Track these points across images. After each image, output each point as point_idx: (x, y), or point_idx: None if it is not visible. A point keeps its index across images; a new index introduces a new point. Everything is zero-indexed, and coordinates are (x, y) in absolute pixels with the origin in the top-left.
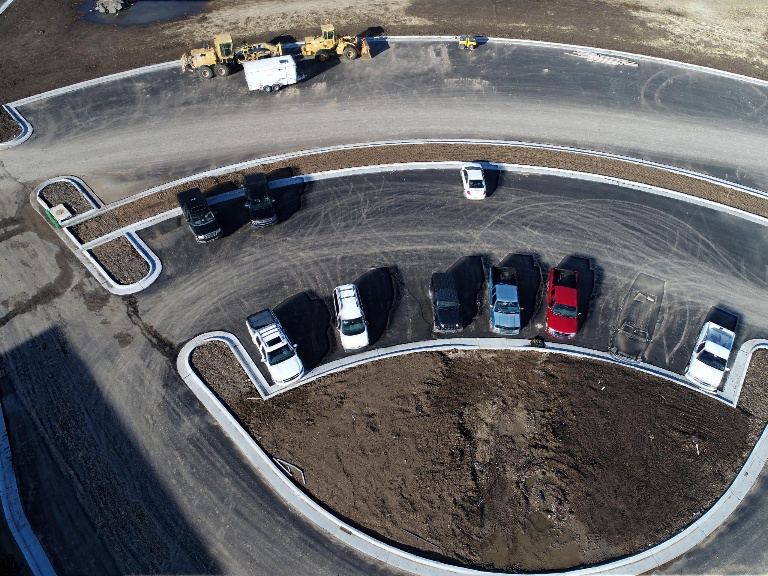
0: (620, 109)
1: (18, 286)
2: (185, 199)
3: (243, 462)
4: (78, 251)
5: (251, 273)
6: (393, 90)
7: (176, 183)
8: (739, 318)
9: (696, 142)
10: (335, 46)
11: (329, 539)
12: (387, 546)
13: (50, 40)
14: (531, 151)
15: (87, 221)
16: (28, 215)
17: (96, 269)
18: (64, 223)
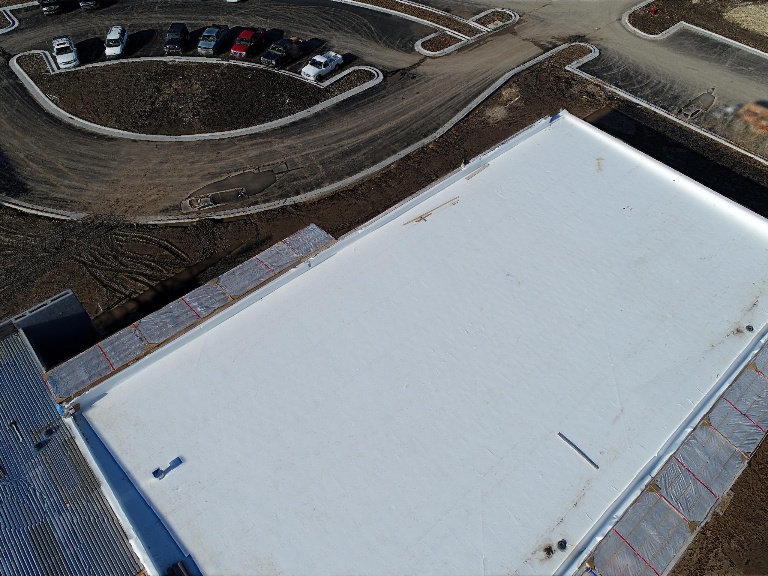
0: None
1: None
2: None
3: (29, 95)
4: None
5: (71, 29)
6: None
7: None
8: (360, 58)
9: None
10: None
11: (61, 120)
12: (89, 123)
13: None
14: None
15: None
16: None
17: None
18: None
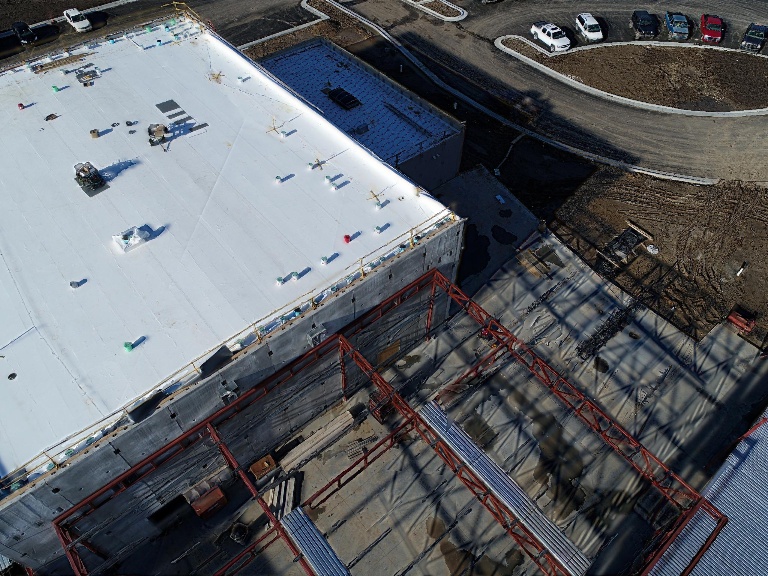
0: None
1: (390, 16)
2: None
3: (547, 75)
4: (415, 5)
5: (521, 16)
6: None
7: None
8: None
9: None
10: None
11: (602, 98)
12: (632, 100)
13: None
14: None
15: None
16: None
17: (430, 12)
18: None
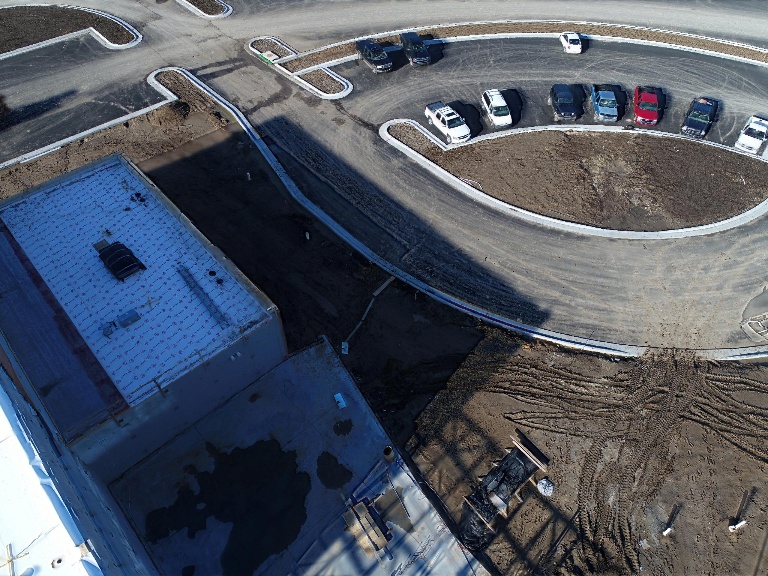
0: (679, 5)
1: (256, 93)
2: (363, 45)
3: (438, 179)
4: (290, 77)
5: (418, 90)
6: None
7: (348, 41)
8: None
9: (740, 26)
10: None
11: (503, 213)
12: (542, 216)
13: None
14: (612, 28)
15: (290, 61)
16: (247, 57)
17: (307, 86)
18: (275, 62)
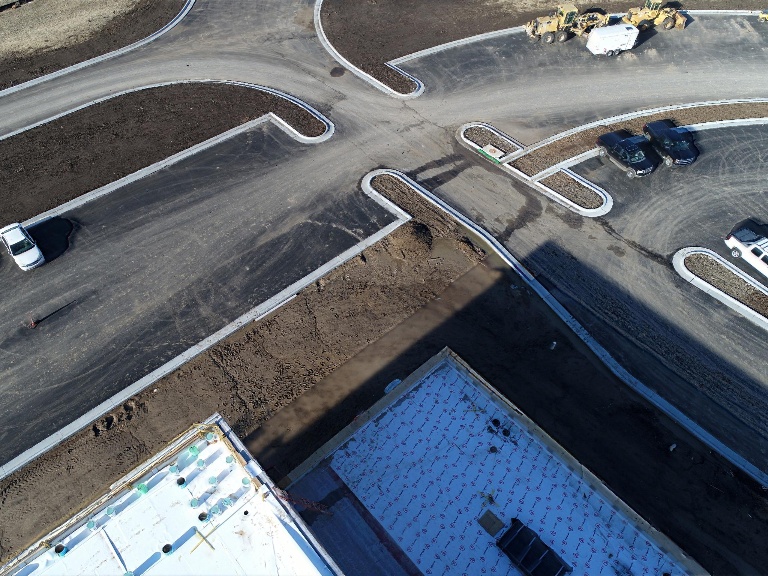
0: None
1: (499, 208)
2: (610, 141)
3: None
4: (529, 182)
5: (692, 203)
6: (720, 56)
7: (577, 130)
8: None
9: None
10: (655, 17)
11: None
12: None
13: (387, 9)
14: None
15: (519, 159)
16: (465, 153)
17: (555, 196)
18: (502, 160)
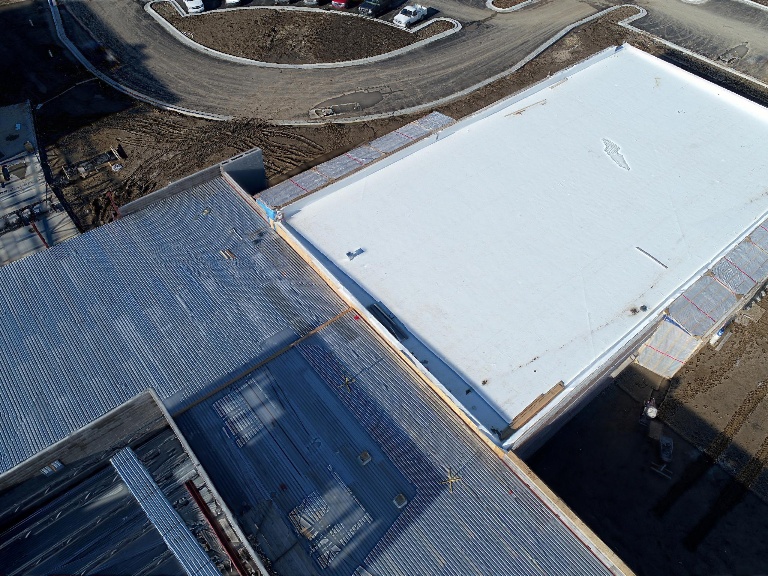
0: None
1: None
2: None
3: (167, 32)
4: None
5: None
6: None
7: None
8: (441, 11)
9: None
10: None
11: (198, 51)
12: (222, 53)
13: None
14: None
15: None
16: None
17: None
18: None
